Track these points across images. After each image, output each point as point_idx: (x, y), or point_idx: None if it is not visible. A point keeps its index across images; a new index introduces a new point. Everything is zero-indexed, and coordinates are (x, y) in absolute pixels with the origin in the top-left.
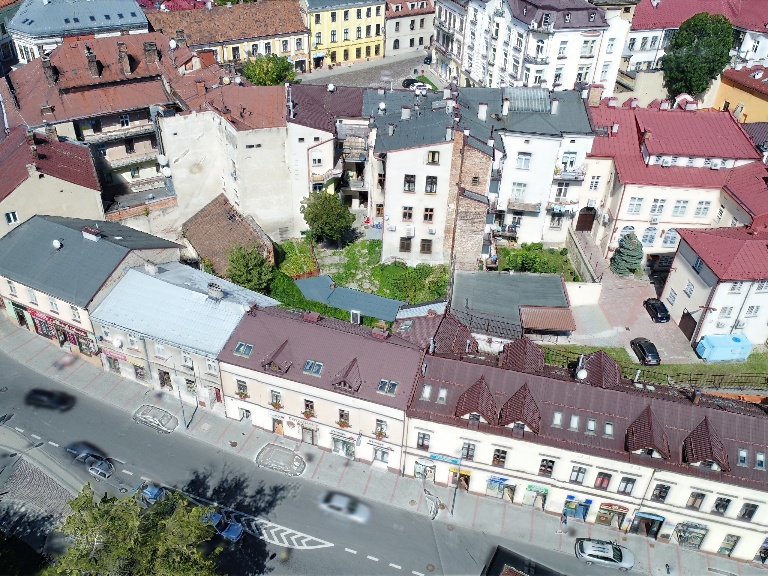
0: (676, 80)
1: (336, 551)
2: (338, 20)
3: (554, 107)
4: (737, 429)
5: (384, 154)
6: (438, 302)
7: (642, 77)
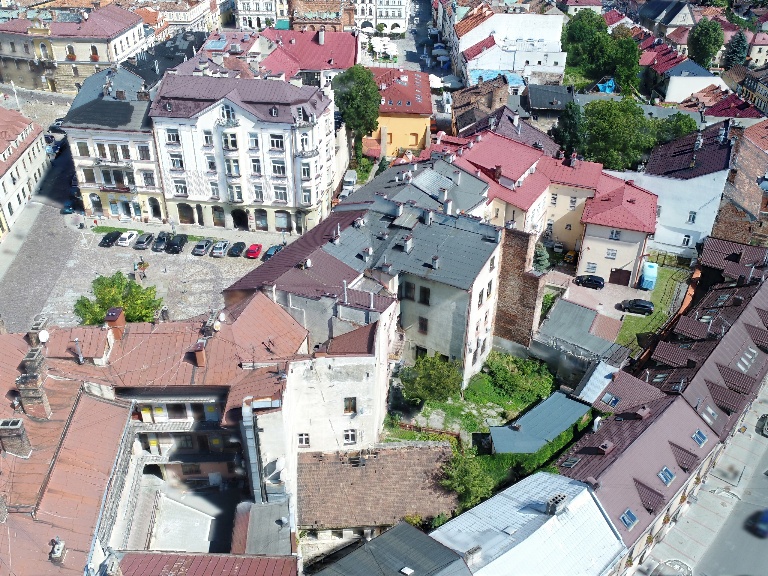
0: (356, 126)
1: None
2: None
3: (459, 179)
4: (764, 302)
5: (472, 285)
6: (596, 367)
7: (340, 134)
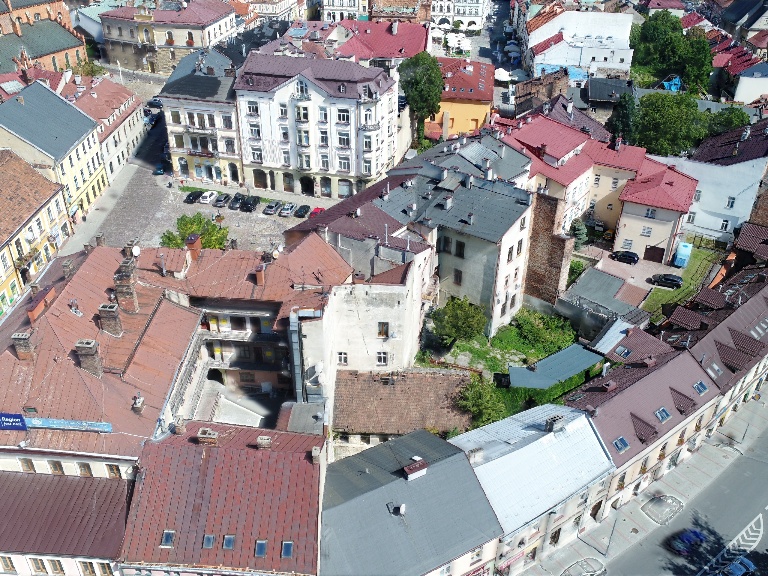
0: (419, 109)
1: (767, 515)
2: (74, 163)
3: (503, 152)
4: None
5: (501, 239)
6: (613, 324)
7: None
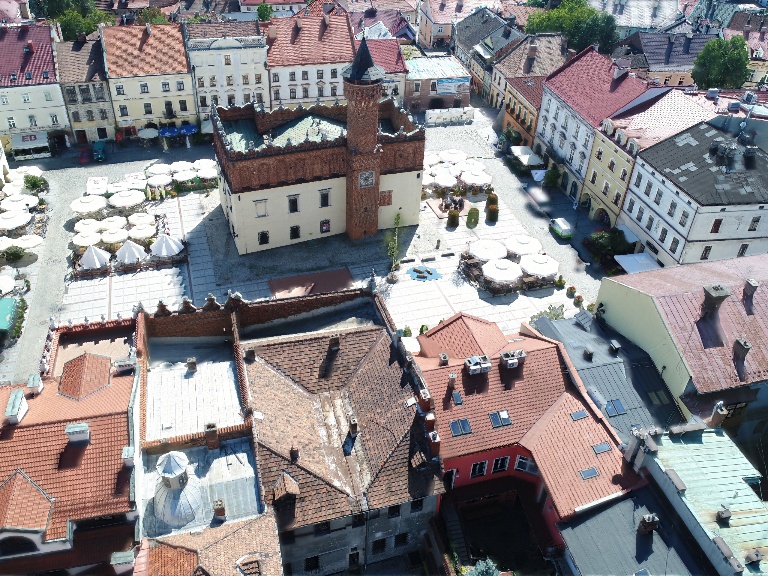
0: None
1: None
2: None
3: None
4: None
5: None
6: None
7: None
